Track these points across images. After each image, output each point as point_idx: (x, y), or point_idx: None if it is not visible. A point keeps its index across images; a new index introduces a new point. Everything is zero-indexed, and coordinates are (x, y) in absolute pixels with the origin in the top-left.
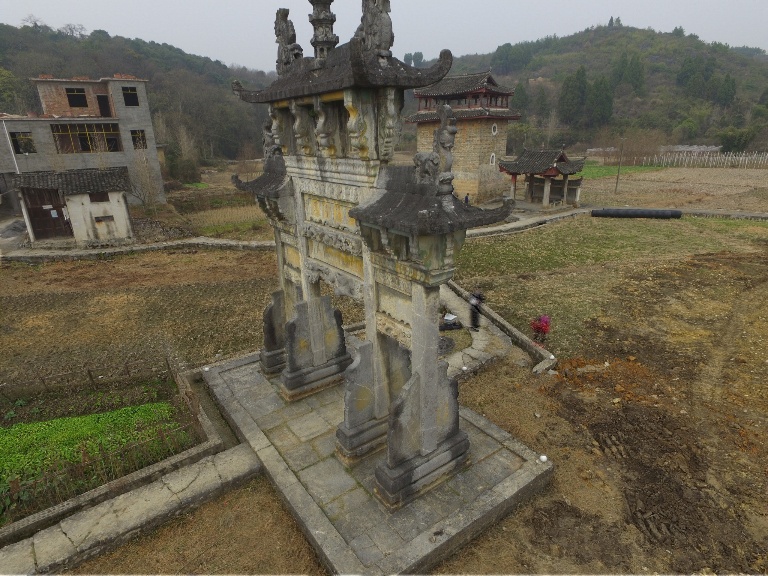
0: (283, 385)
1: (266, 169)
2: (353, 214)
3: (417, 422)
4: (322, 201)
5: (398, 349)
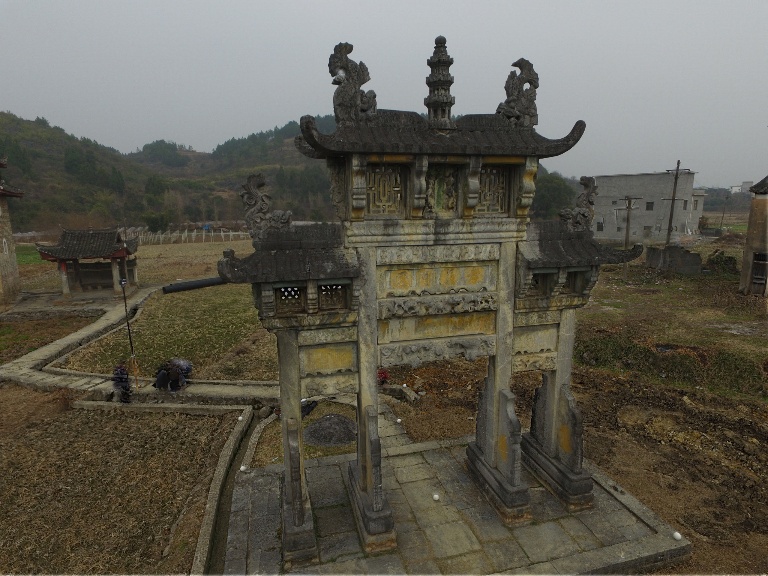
0: (373, 536)
1: (268, 246)
2: (538, 264)
3: None
4: (419, 269)
5: None
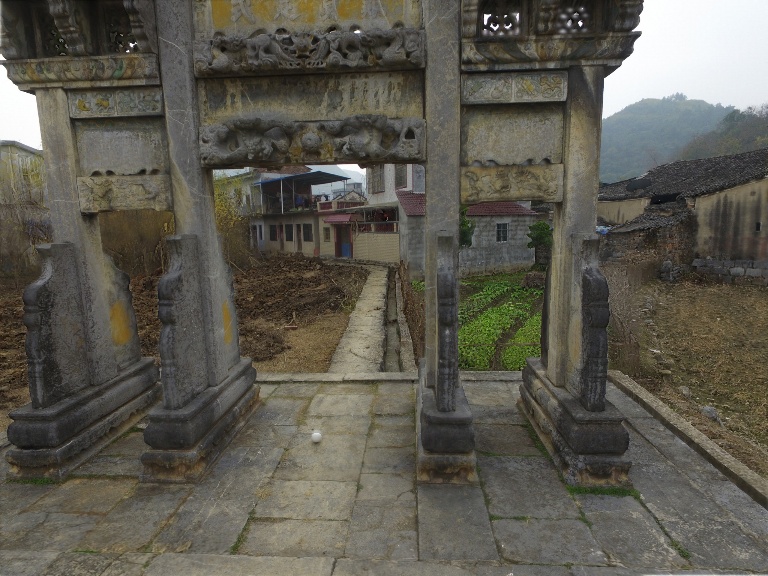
0: None
1: None
2: None
3: None
4: None
5: None
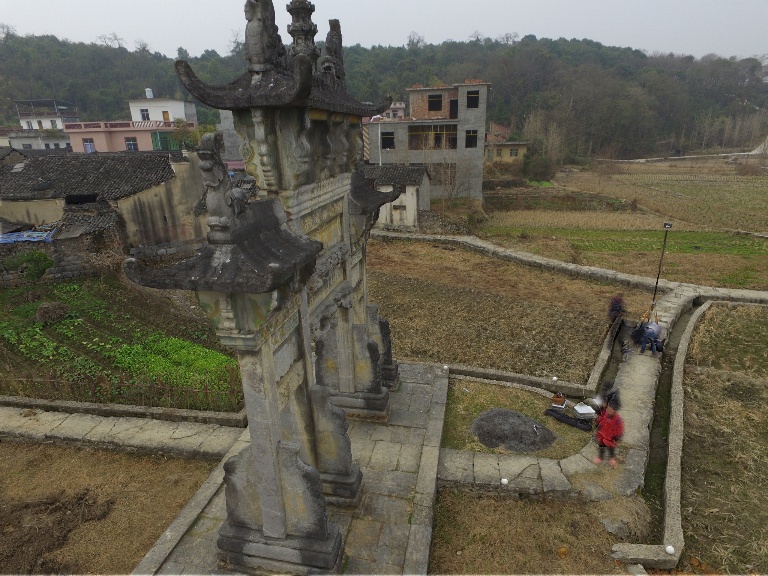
0: None
1: None
2: None
3: (257, 494)
4: None
5: (326, 408)
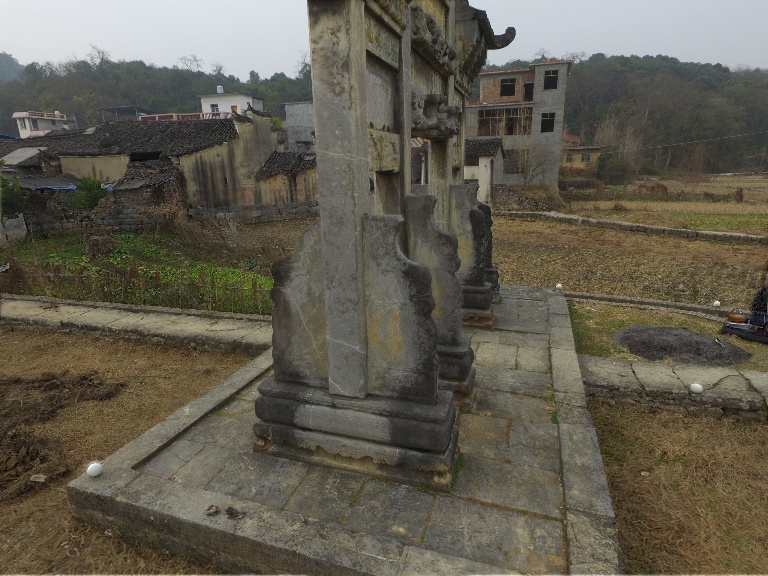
0: None
1: None
2: None
3: (323, 317)
4: None
5: (429, 228)
